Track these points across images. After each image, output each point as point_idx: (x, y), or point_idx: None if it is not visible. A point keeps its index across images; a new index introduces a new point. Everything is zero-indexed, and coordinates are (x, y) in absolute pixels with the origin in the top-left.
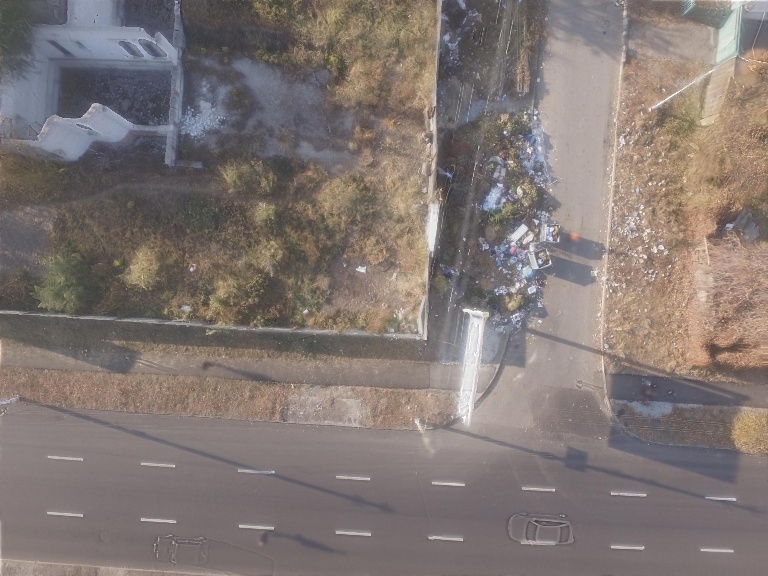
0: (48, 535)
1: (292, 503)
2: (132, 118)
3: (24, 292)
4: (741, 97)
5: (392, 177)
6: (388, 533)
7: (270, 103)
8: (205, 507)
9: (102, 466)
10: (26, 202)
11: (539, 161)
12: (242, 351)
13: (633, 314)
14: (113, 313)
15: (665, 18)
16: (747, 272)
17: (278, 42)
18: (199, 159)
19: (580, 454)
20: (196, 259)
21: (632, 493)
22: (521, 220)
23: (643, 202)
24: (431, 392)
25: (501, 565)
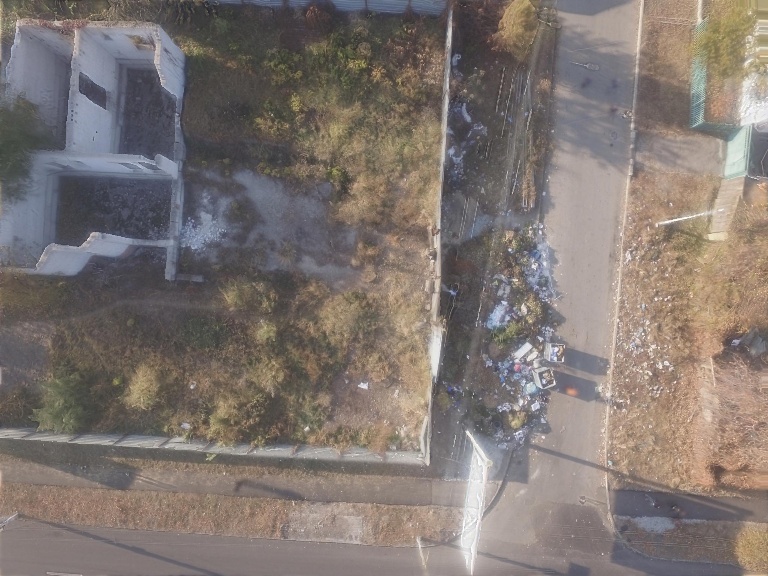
0: None
1: None
2: (132, 227)
3: (23, 410)
4: (750, 228)
5: (395, 294)
6: None
7: (272, 216)
8: None
9: None
10: (24, 318)
11: (544, 276)
12: (243, 468)
13: (637, 431)
14: (112, 431)
15: (673, 130)
16: (754, 405)
17: (280, 154)
18: (200, 272)
19: (582, 570)
20: (196, 377)
21: None
22: (525, 338)
23: (649, 318)
24: (433, 509)
25: None
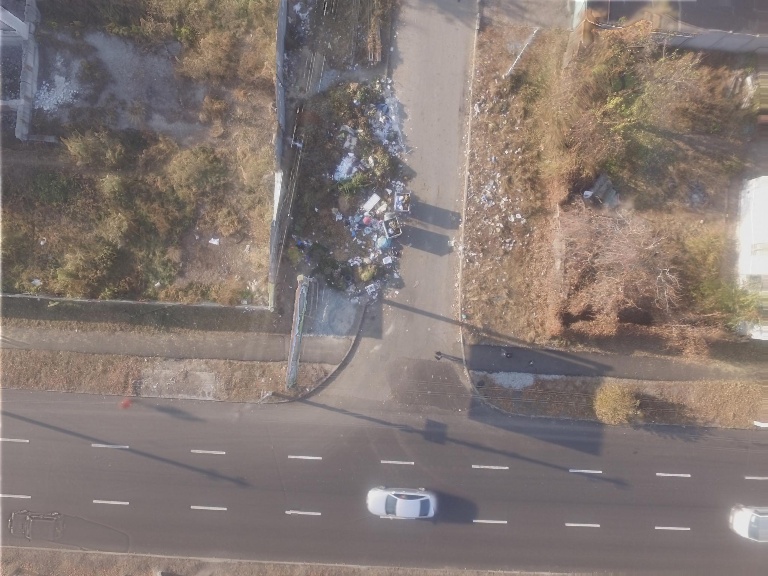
0: None
1: (147, 477)
2: None
3: None
4: (577, 59)
5: (243, 148)
6: (244, 507)
7: (122, 76)
8: (59, 482)
9: None
10: None
11: (393, 130)
12: (94, 325)
13: (490, 284)
14: None
15: None
16: (586, 236)
17: (130, 15)
18: (53, 133)
19: (440, 426)
20: (46, 232)
21: (494, 466)
22: (373, 189)
23: (499, 170)
24: (286, 364)
25: (360, 539)
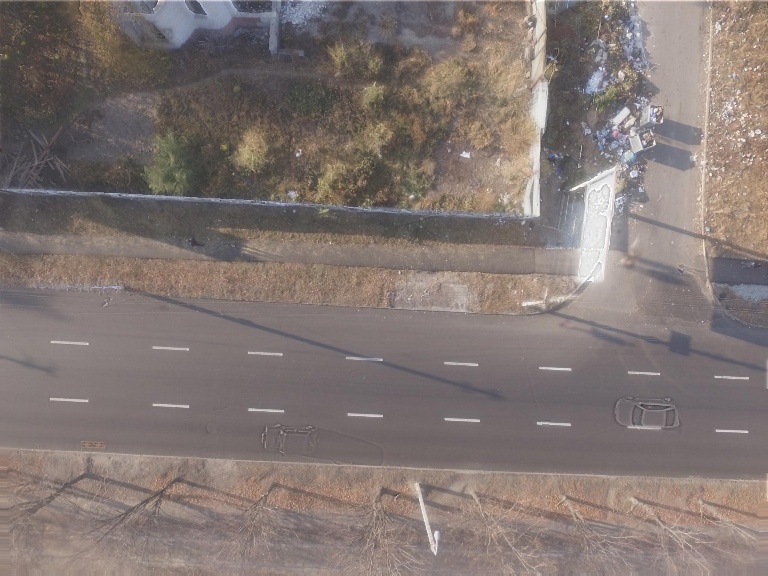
0: (154, 427)
1: (400, 390)
2: None
3: (130, 178)
4: None
5: (495, 62)
6: (497, 419)
7: None
8: (313, 395)
9: (208, 356)
10: (129, 89)
11: (637, 47)
12: (348, 237)
13: (733, 197)
14: None
15: None
16: None
17: None
18: (300, 48)
19: (683, 338)
20: (302, 144)
21: (735, 376)
22: (623, 103)
23: (740, 87)
24: (536, 277)
25: (609, 450)
